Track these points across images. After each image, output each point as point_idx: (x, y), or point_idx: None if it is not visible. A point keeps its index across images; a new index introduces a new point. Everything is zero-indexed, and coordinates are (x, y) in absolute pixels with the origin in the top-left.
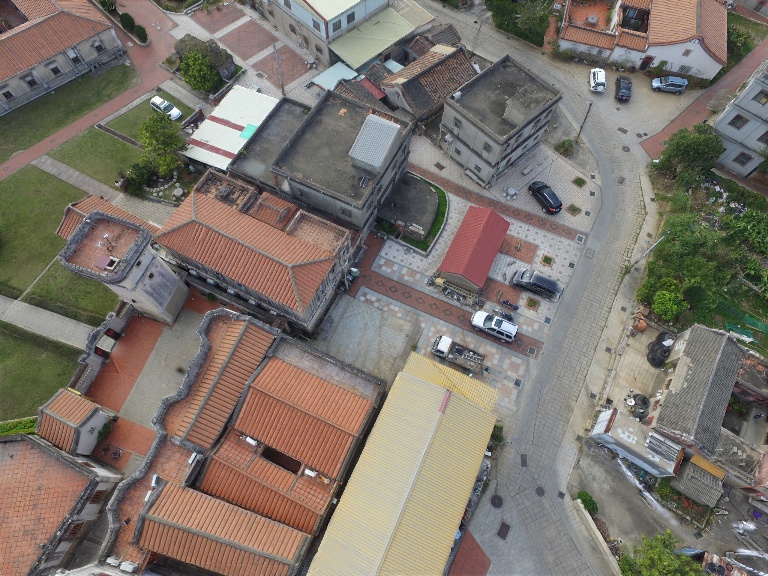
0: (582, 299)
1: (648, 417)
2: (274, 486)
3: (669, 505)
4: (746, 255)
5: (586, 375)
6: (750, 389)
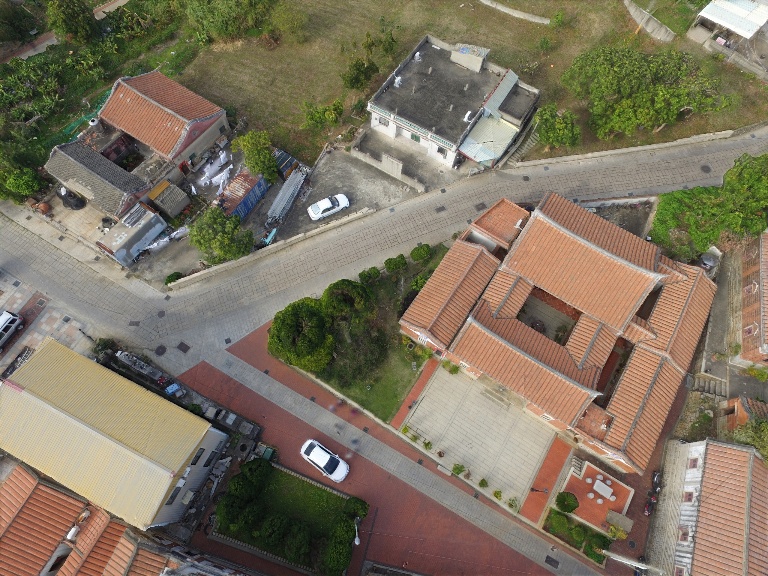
0: (7, 250)
1: (117, 221)
2: (71, 575)
3: (187, 223)
4: (4, 114)
5: (77, 261)
6: (110, 146)
